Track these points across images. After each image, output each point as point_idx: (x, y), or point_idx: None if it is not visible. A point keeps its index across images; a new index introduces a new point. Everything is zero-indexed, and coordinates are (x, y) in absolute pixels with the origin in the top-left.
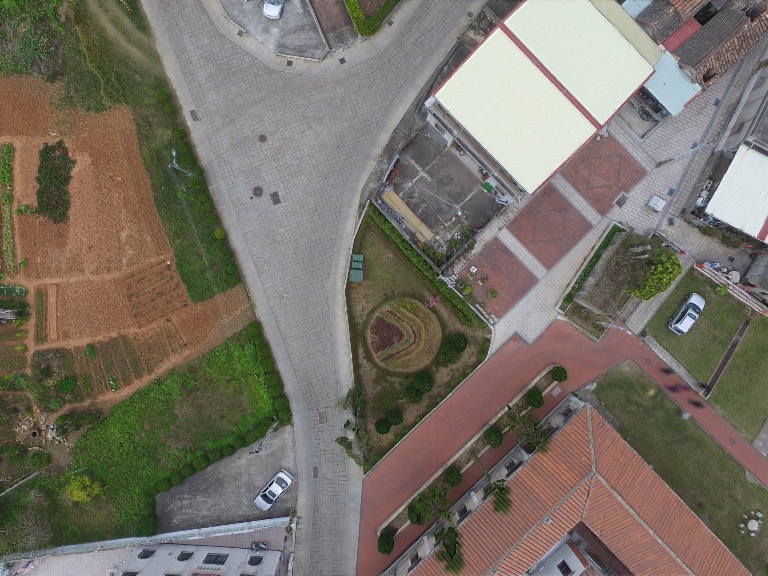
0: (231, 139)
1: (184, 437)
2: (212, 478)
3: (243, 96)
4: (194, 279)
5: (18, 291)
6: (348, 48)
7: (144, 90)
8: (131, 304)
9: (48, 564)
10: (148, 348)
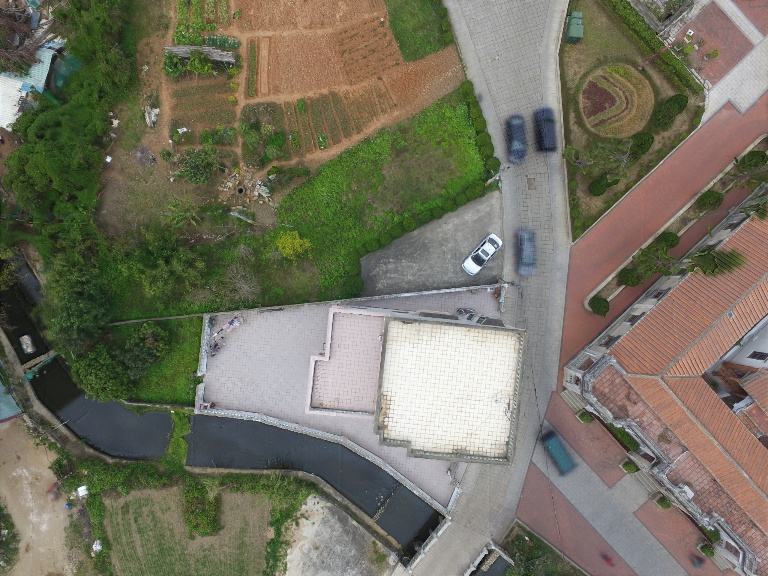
0: None
1: (391, 199)
2: (418, 243)
3: None
4: (407, 37)
5: (231, 41)
6: None
7: None
8: (343, 60)
9: (250, 325)
10: (358, 107)
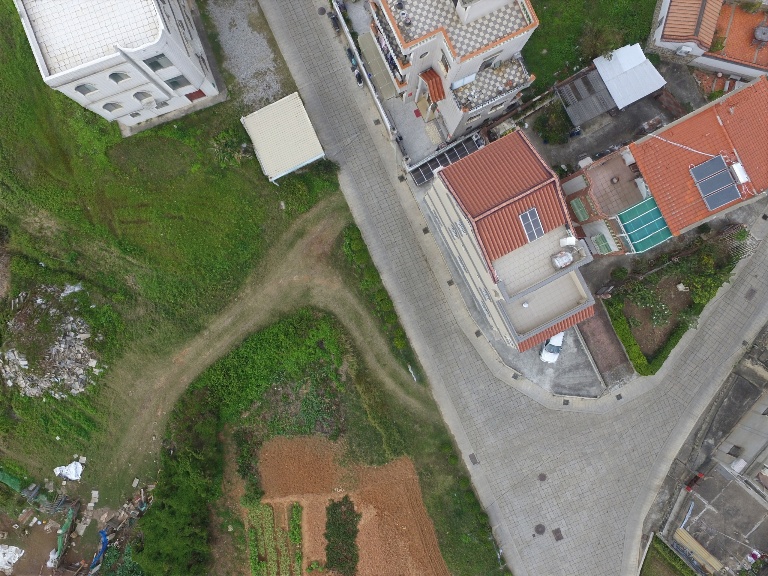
0: (511, 479)
1: None
2: None
3: (521, 437)
4: None
5: None
6: (624, 384)
7: (424, 439)
8: None
9: None
10: None
